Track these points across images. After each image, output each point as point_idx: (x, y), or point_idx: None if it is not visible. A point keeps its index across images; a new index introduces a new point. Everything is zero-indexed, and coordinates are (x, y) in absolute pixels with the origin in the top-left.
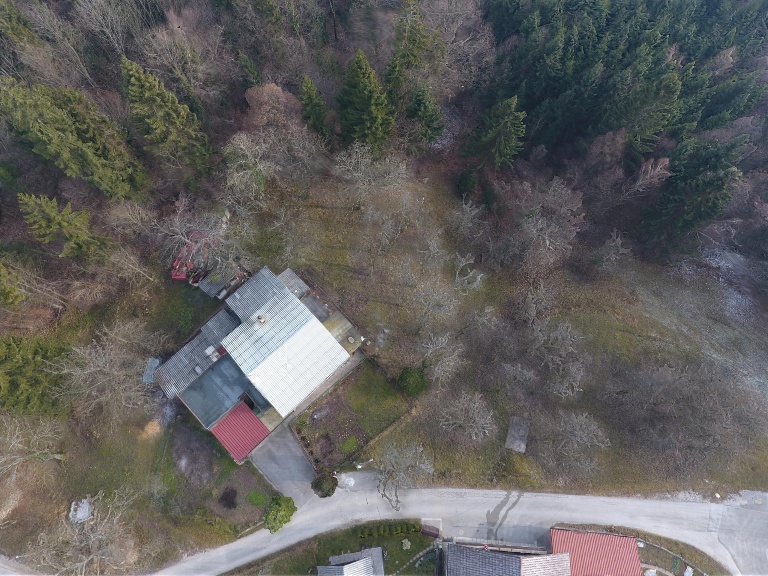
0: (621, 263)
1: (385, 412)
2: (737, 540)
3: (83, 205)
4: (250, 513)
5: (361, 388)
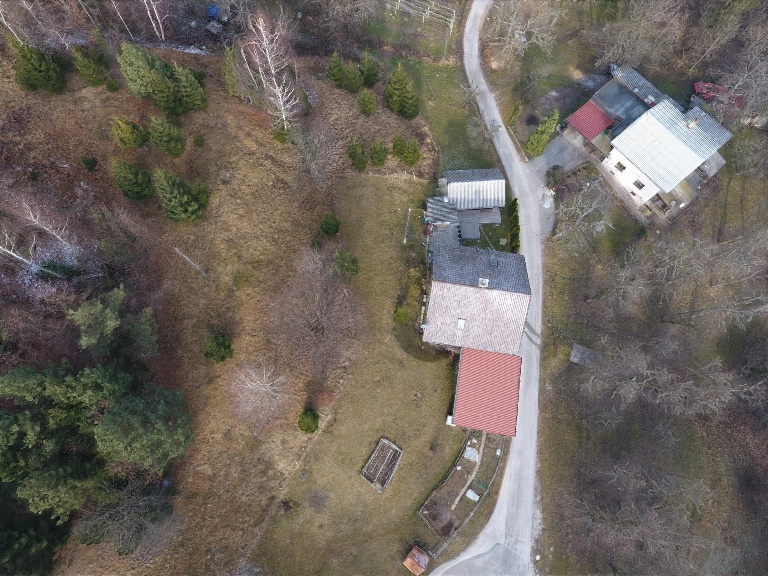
0: (765, 540)
1: (599, 240)
2: (497, 566)
3: (766, 3)
4: (523, 134)
5: (619, 221)
